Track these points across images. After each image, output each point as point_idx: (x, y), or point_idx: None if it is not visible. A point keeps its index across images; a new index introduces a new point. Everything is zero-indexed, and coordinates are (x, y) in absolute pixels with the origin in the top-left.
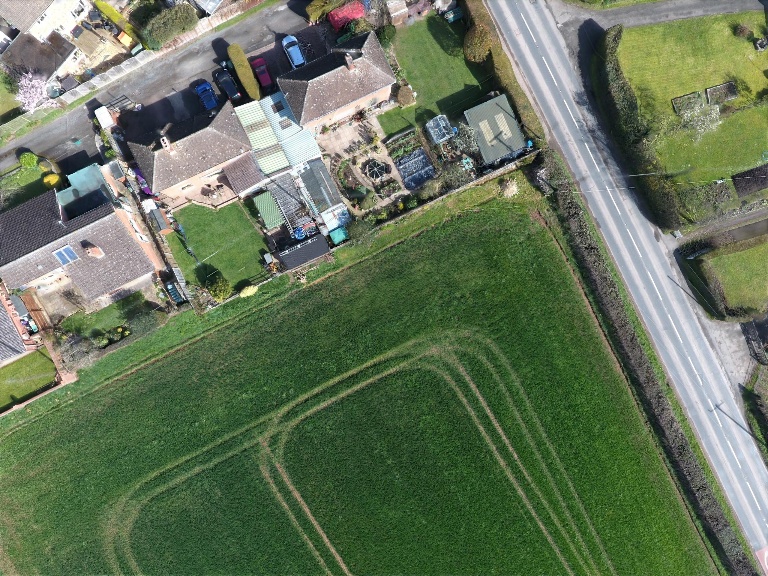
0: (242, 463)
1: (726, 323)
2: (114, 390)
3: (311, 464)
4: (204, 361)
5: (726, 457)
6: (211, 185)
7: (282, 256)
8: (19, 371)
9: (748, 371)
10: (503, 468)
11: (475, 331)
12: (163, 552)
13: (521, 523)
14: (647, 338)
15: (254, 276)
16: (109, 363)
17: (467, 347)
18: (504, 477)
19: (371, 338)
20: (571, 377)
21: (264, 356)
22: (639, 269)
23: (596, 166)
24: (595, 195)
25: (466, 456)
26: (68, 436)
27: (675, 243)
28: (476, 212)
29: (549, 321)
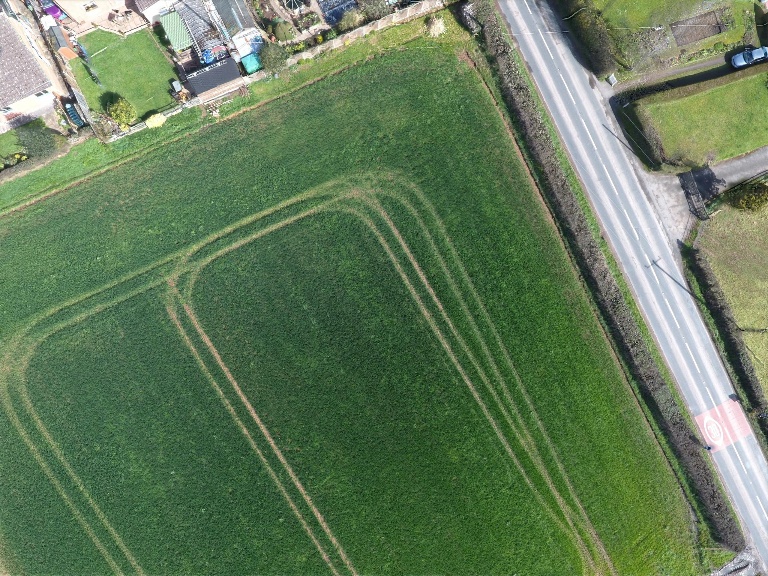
0: (147, 302)
1: (664, 176)
2: (11, 221)
3: (221, 306)
4: (108, 194)
5: (664, 316)
6: (119, 11)
7: (189, 79)
8: None
9: (687, 227)
10: (427, 319)
11: (398, 174)
12: (60, 393)
13: (445, 377)
14: (580, 188)
15: (163, 107)
16: (6, 192)
17: (390, 190)
18: (428, 328)
19: (287, 176)
20: (500, 225)
21: (173, 191)
22: (572, 116)
23: (528, 8)
24: (527, 38)
25: (387, 304)
26: None
27: (611, 91)
28: (401, 51)
29: (477, 166)
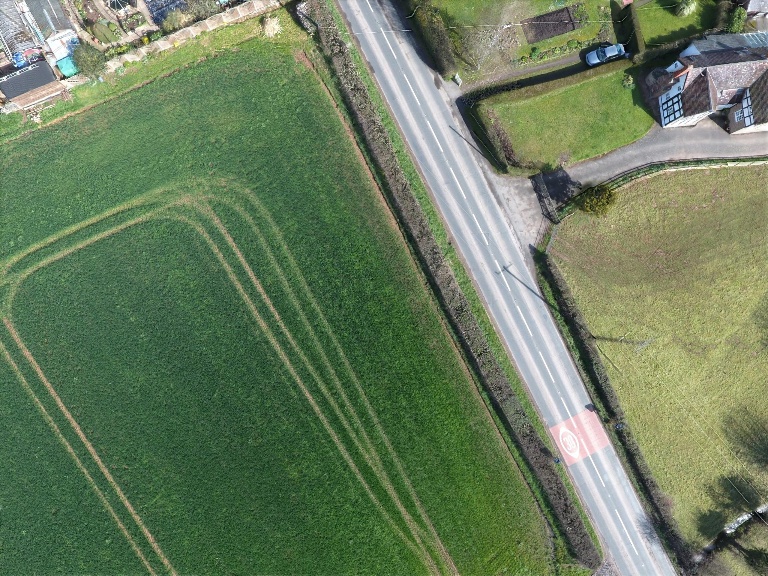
0: None
1: (515, 179)
2: None
3: (42, 319)
4: None
5: (515, 324)
6: None
7: None
8: None
9: (540, 231)
10: (263, 330)
11: (232, 180)
12: None
13: (283, 390)
14: (425, 192)
15: None
16: None
17: (223, 197)
18: (264, 339)
19: (112, 183)
20: (339, 232)
21: None
22: (417, 118)
23: (369, 6)
24: (368, 37)
25: (220, 315)
26: None
27: (458, 91)
28: (235, 52)
29: (315, 171)
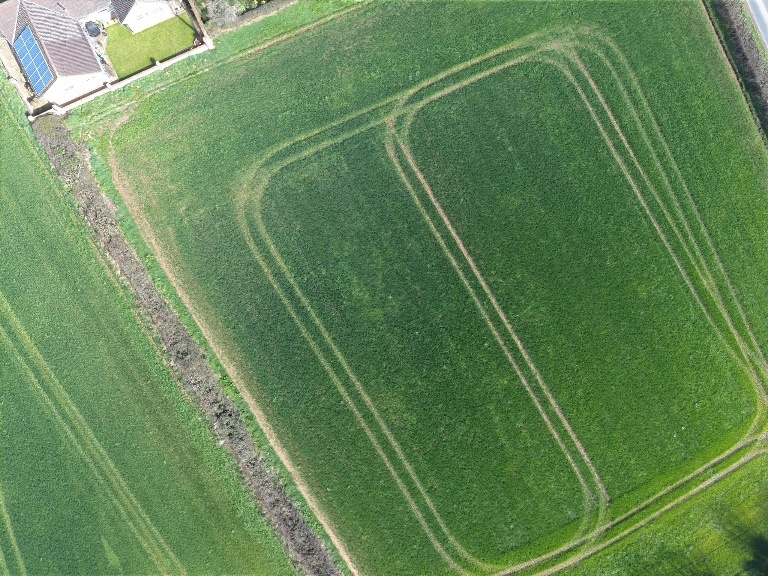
0: (369, 140)
1: None
2: (248, 62)
3: (435, 146)
4: (334, 39)
5: None
6: None
7: None
8: (159, 35)
9: None
10: (619, 164)
11: (595, 28)
12: (292, 220)
13: (636, 218)
14: (762, 45)
15: None
16: (244, 35)
17: (587, 44)
18: (620, 172)
19: (495, 27)
20: (688, 78)
21: (392, 39)
22: None
23: None
24: None
25: (584, 149)
26: (204, 102)
27: None
28: None
29: (667, 23)
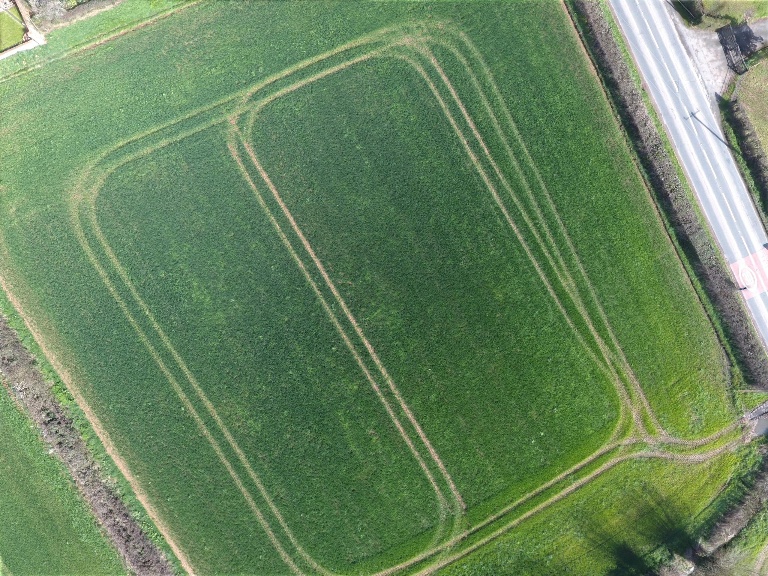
0: (209, 138)
1: (704, 32)
2: (82, 58)
3: (279, 144)
4: (173, 34)
5: (701, 166)
6: None
7: None
8: None
9: (725, 81)
10: (474, 163)
11: (448, 23)
12: (128, 221)
13: (491, 218)
14: (623, 40)
15: None
16: (78, 30)
17: (440, 39)
18: (475, 171)
19: (342, 22)
20: (544, 74)
21: (234, 34)
22: None
23: None
24: None
25: (436, 147)
26: (35, 99)
27: None
28: None
29: (523, 17)
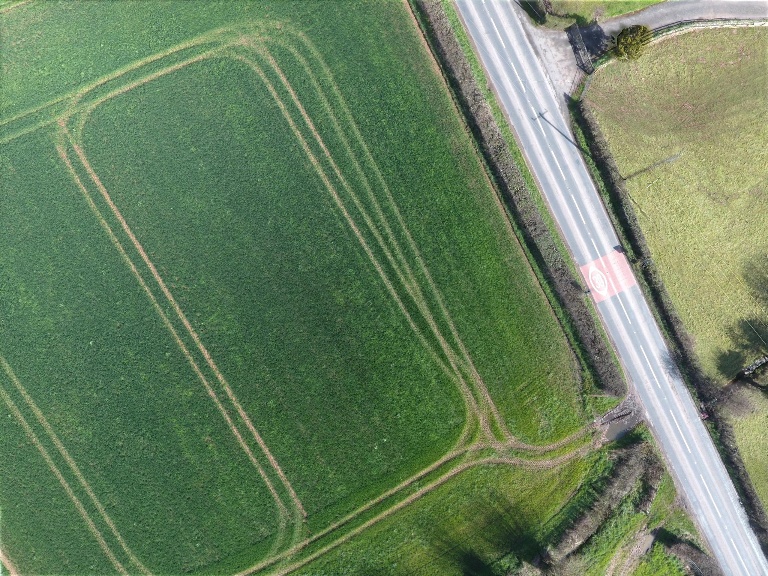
0: (37, 140)
1: (552, 31)
2: None
3: (110, 146)
4: None
5: (550, 167)
6: None
7: None
8: None
9: (574, 81)
10: (314, 165)
11: (286, 22)
12: None
13: (331, 221)
14: (467, 40)
15: None
16: None
17: (278, 38)
18: (314, 173)
19: (176, 22)
20: (386, 74)
21: (63, 34)
22: None
23: None
24: None
25: (274, 148)
26: None
27: None
28: None
29: (364, 16)
